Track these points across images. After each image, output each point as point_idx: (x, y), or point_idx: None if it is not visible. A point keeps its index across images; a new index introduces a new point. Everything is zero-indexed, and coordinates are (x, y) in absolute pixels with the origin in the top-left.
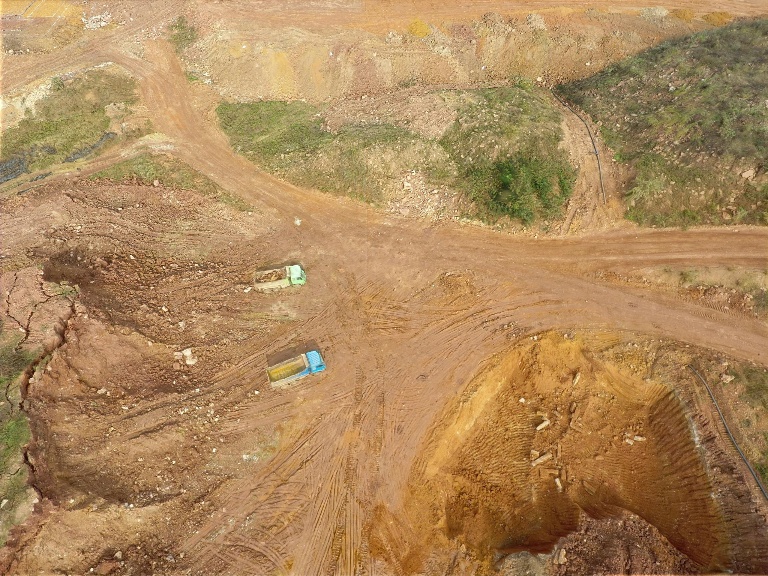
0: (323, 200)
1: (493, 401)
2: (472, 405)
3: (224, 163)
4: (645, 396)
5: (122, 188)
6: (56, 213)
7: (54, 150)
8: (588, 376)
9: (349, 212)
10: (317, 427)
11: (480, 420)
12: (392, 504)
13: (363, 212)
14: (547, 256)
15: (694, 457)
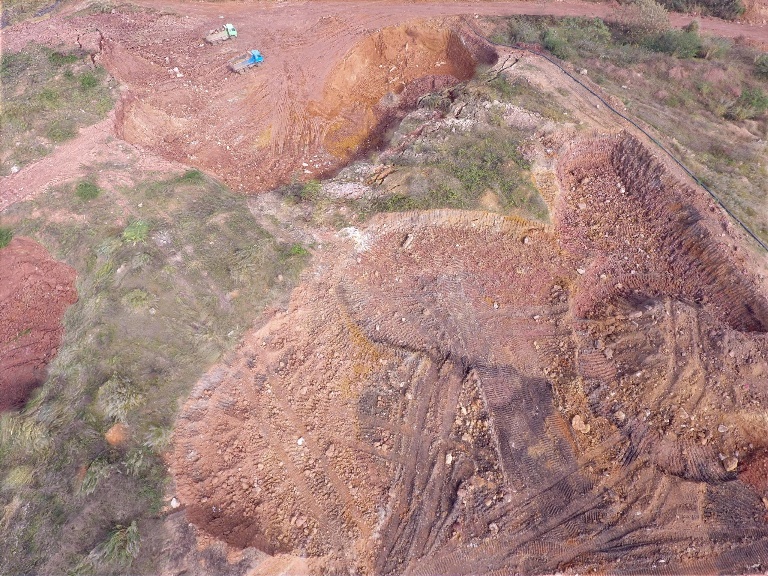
0: (234, 5)
1: (365, 69)
2: (351, 62)
3: (157, 1)
4: (442, 43)
5: (90, 18)
6: (52, 27)
7: (23, 12)
8: (412, 45)
9: (254, 7)
10: (267, 84)
11: (359, 75)
12: (317, 99)
13: (263, 5)
14: (380, 0)
15: (464, 50)
